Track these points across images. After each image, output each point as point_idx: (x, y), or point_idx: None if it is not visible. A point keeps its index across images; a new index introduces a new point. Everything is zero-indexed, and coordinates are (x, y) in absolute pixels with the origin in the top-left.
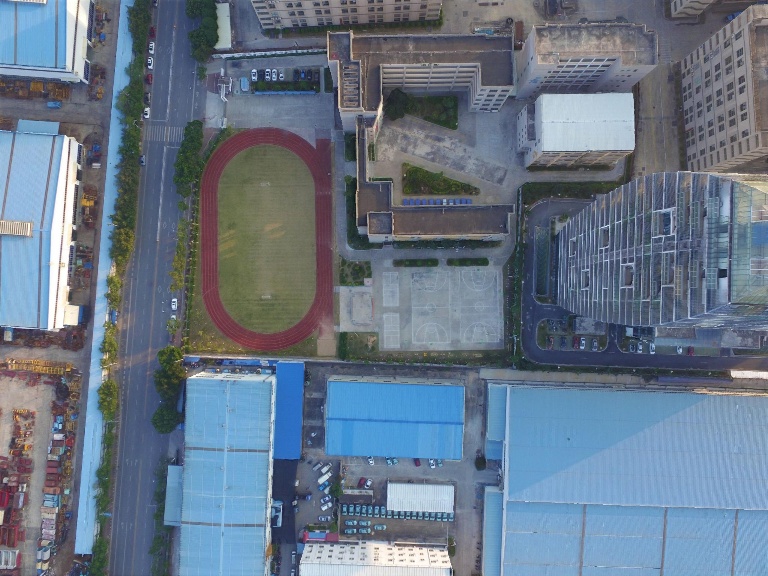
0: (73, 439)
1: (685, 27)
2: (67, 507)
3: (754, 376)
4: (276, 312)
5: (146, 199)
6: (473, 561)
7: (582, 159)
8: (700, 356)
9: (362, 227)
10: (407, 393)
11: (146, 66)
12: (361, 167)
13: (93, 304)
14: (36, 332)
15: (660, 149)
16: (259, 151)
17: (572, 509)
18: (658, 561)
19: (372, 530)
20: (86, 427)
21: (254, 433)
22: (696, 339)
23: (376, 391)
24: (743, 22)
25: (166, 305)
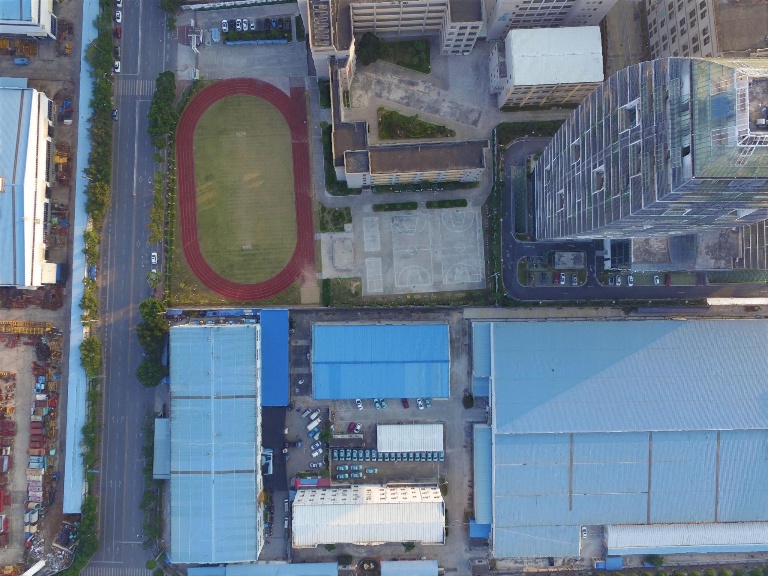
0: (56, 399)
1: None
2: (53, 468)
3: (729, 302)
4: (258, 262)
5: (120, 154)
6: (465, 499)
7: (554, 95)
8: (677, 286)
9: (339, 167)
10: (392, 334)
11: (114, 20)
12: (336, 108)
13: (71, 262)
14: (13, 293)
15: None
16: (233, 102)
17: (559, 439)
18: (645, 485)
19: (364, 474)
20: (69, 385)
21: (240, 379)
22: (671, 263)
23: (361, 333)
24: None
25: (146, 260)
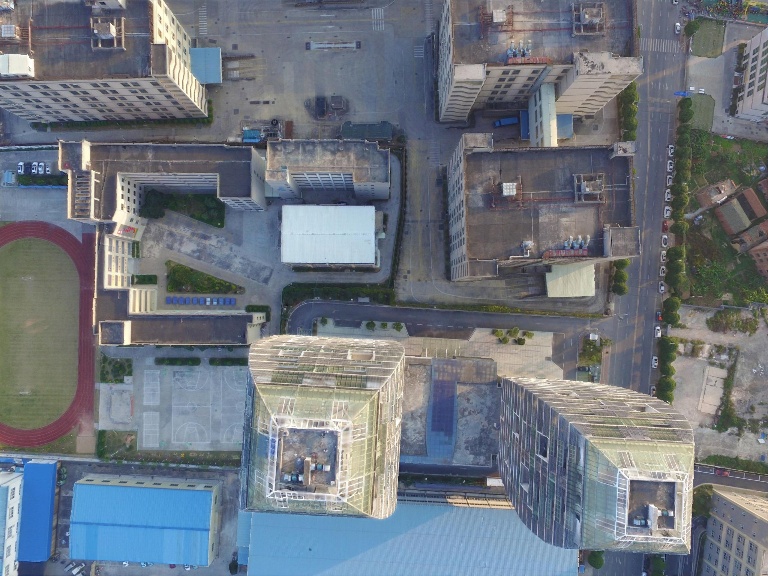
0: None
1: (455, 131)
2: None
3: None
4: (36, 408)
5: None
6: None
7: (336, 265)
8: None
9: None
10: (154, 497)
11: None
12: (100, 273)
13: None
14: None
15: (426, 252)
16: (24, 244)
17: None
18: None
19: None
20: None
21: None
22: (427, 456)
23: (123, 495)
24: (461, 148)
25: None
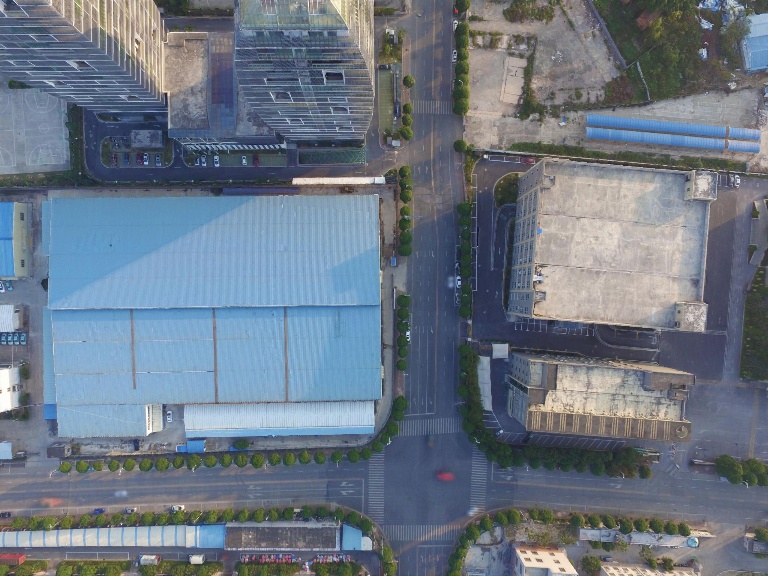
0: None
1: None
2: None
3: (315, 182)
4: None
5: None
6: None
7: None
8: (267, 167)
9: None
10: None
11: None
12: None
13: None
14: None
15: None
16: None
17: (119, 315)
18: (211, 364)
19: None
20: None
21: None
22: (209, 129)
23: None
24: None
25: None
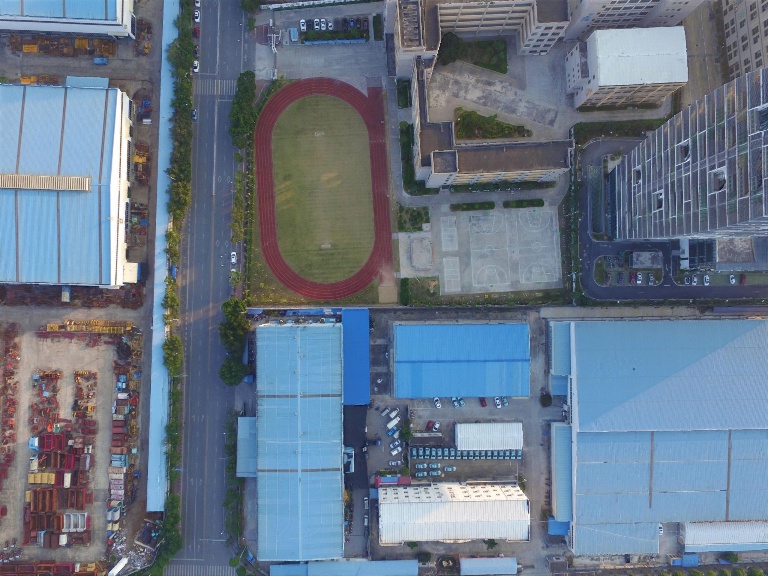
0: (137, 398)
1: None
2: (134, 467)
3: None
4: (336, 261)
5: (199, 154)
6: (542, 497)
7: (633, 96)
8: (752, 285)
9: (426, 167)
10: (473, 333)
11: (193, 19)
12: (422, 108)
13: (151, 261)
14: (94, 292)
15: (705, 86)
16: (311, 101)
17: (640, 437)
18: (724, 483)
19: (442, 472)
20: (152, 384)
21: (326, 378)
22: (755, 263)
23: (442, 332)
24: None
25: (225, 259)
